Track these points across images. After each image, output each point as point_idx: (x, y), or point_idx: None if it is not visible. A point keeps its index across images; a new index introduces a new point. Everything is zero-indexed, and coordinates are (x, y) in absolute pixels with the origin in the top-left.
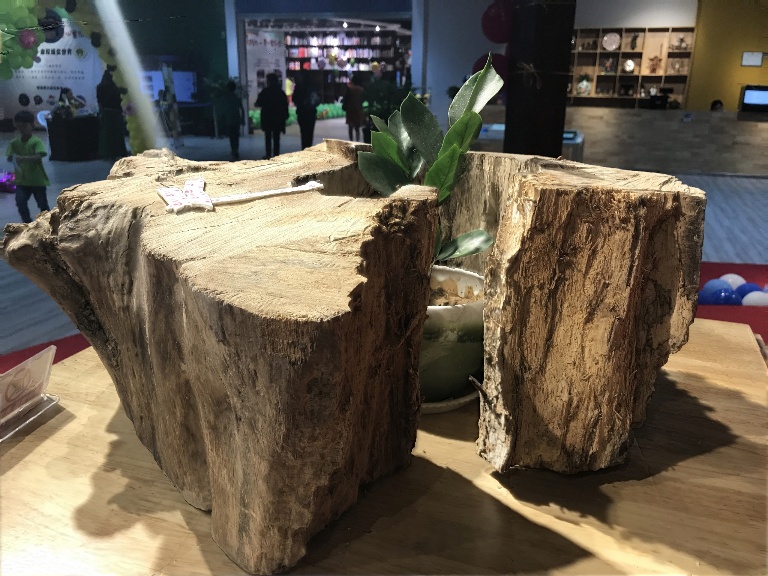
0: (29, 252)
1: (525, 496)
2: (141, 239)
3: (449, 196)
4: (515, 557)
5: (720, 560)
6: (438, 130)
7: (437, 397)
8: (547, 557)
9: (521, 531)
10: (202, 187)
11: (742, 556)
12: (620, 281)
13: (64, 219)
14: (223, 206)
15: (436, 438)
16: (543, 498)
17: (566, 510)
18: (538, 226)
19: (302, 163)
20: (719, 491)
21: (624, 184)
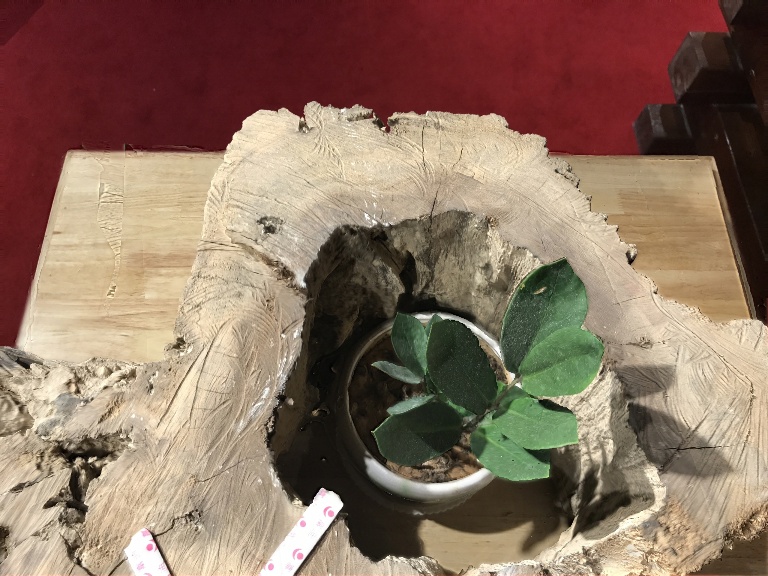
0: None
1: None
2: None
3: (430, 247)
4: None
5: None
6: (475, 344)
7: None
8: None
9: None
10: None
11: None
12: None
13: None
14: None
15: (472, 538)
16: None
17: None
18: None
19: (233, 338)
20: None
21: (757, 477)
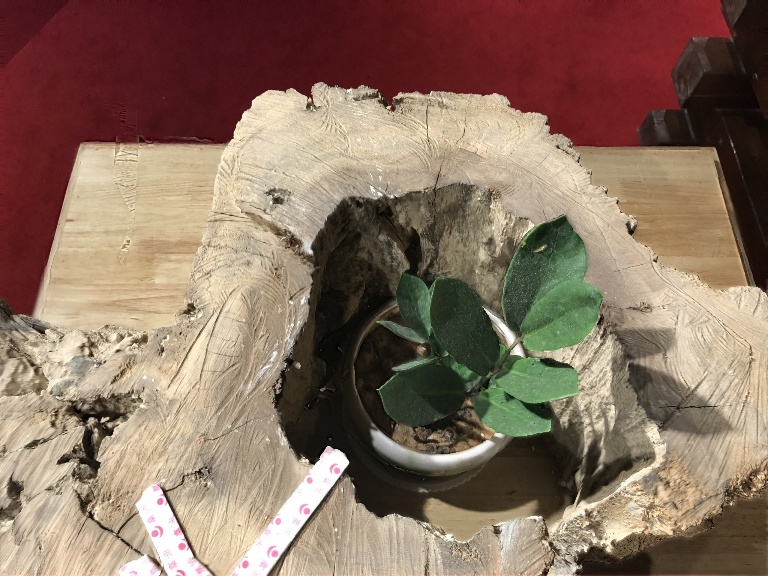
0: None
1: None
2: None
3: (435, 222)
4: None
5: None
6: (478, 304)
7: None
8: None
9: None
10: (179, 531)
11: None
12: None
13: None
14: None
15: (477, 516)
16: None
17: None
18: None
19: (242, 304)
20: (727, 507)
21: (757, 436)
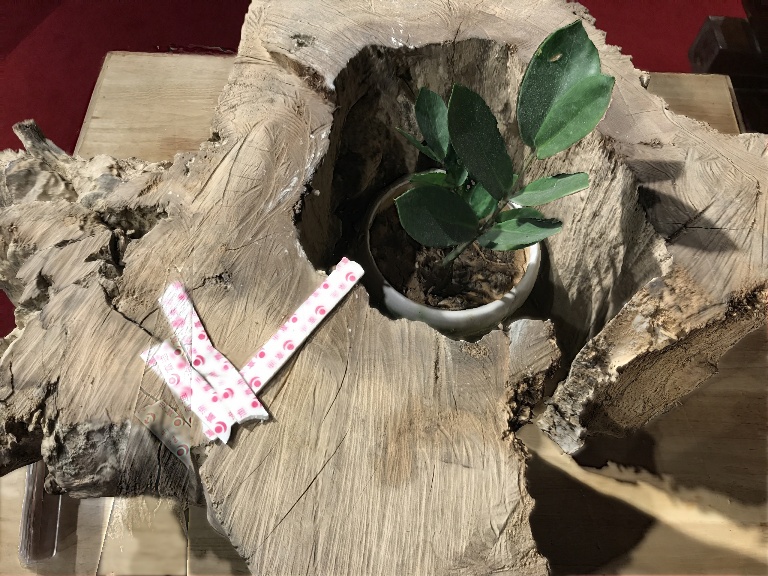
0: (2, 471)
1: (586, 459)
2: (241, 556)
3: None
4: (599, 543)
5: (744, 492)
6: (494, 124)
7: (471, 340)
8: (622, 534)
9: (595, 508)
10: (199, 323)
11: (757, 480)
12: (727, 343)
13: (50, 460)
14: (270, 390)
15: None
16: (600, 456)
17: (622, 467)
18: (669, 347)
19: (265, 135)
20: (732, 397)
21: (762, 256)
